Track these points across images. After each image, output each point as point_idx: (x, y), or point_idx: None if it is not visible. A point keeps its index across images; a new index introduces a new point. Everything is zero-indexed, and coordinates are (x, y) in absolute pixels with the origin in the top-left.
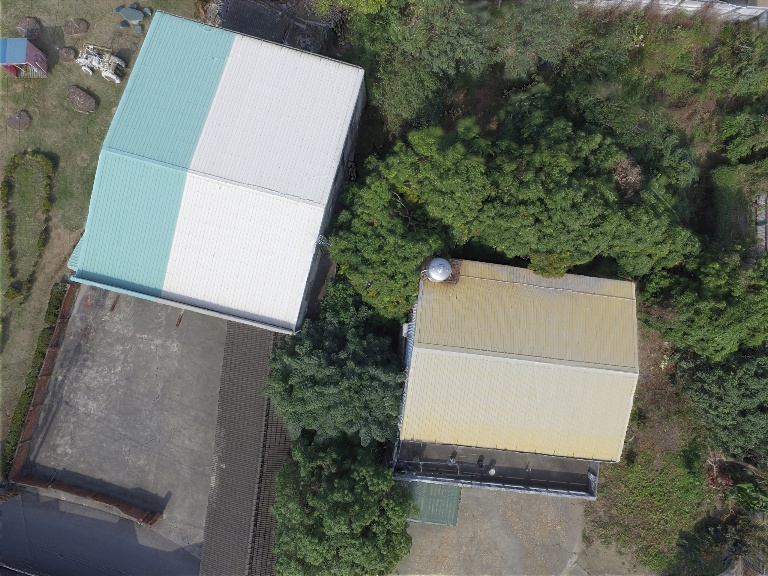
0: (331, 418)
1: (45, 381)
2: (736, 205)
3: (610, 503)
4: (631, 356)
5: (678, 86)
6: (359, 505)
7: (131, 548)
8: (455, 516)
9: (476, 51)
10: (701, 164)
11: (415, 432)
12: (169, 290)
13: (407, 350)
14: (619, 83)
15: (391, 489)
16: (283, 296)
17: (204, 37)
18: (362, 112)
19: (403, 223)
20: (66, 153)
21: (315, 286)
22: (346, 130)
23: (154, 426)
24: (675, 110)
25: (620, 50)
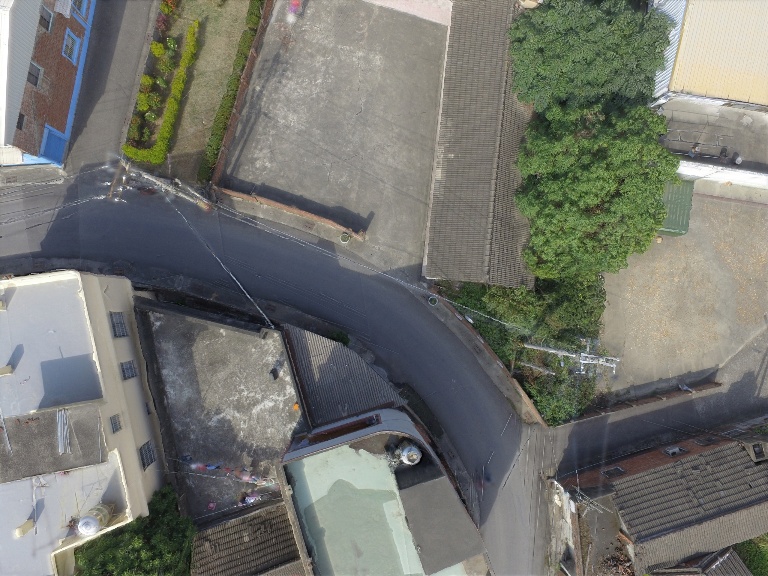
0: (595, 68)
1: (243, 90)
2: None
3: None
4: None
5: None
6: None
7: (332, 270)
8: (687, 222)
9: None
10: None
11: (686, 83)
12: None
13: None
14: None
15: None
16: None
17: None
18: None
19: None
20: None
21: None
22: None
23: (357, 141)
24: None
25: None
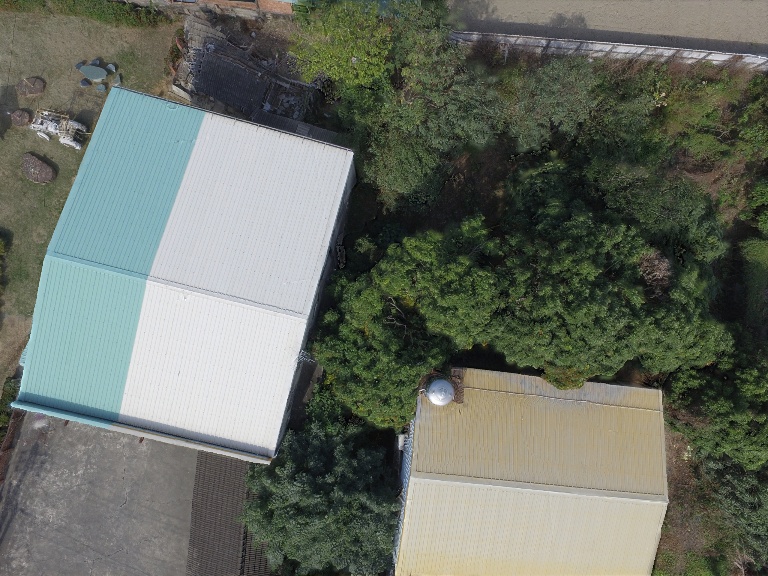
0: (316, 553)
1: None
2: None
3: None
4: (659, 480)
5: (703, 148)
6: None
7: None
8: None
9: (481, 121)
10: (728, 234)
11: (413, 569)
12: (127, 413)
13: (403, 465)
14: (638, 146)
15: None
16: (260, 418)
17: (168, 116)
18: (352, 188)
19: (398, 334)
20: (20, 229)
21: (299, 387)
22: (332, 225)
23: (121, 535)
24: (700, 176)
25: (640, 111)
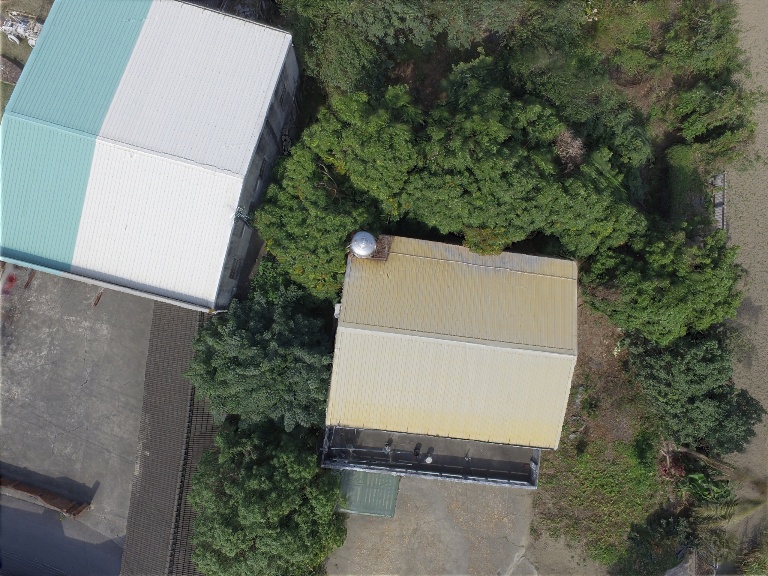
0: (253, 402)
1: None
2: (691, 186)
3: (559, 494)
4: (569, 338)
5: (633, 63)
6: (277, 493)
7: (56, 540)
8: (393, 507)
9: (415, 20)
10: (657, 144)
11: (341, 417)
12: (78, 265)
13: None
14: (572, 59)
15: (317, 477)
16: (201, 272)
17: None
18: (298, 84)
19: (328, 195)
20: None
21: (246, 265)
22: (269, 97)
23: (81, 412)
24: (630, 88)
25: (572, 24)
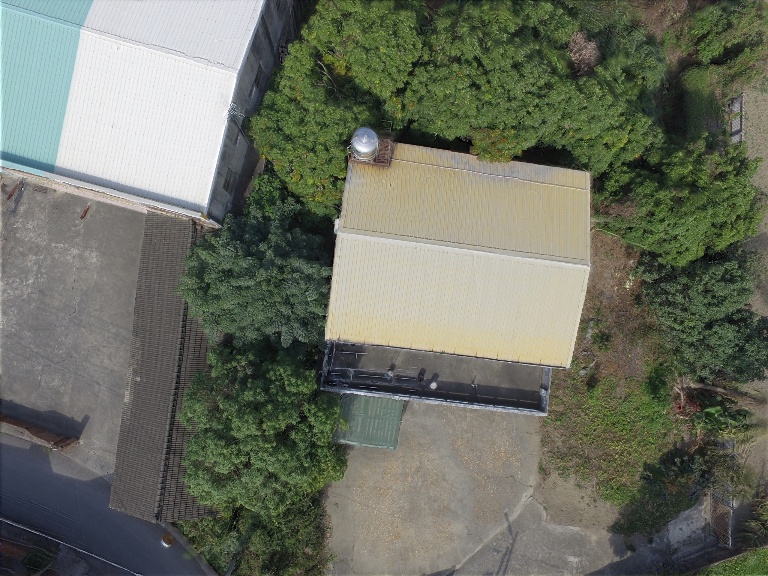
0: (248, 315)
1: None
2: (707, 109)
3: (569, 432)
4: (582, 249)
5: None
6: (273, 405)
7: (44, 476)
8: (395, 438)
9: None
10: (671, 69)
11: (342, 331)
12: (62, 166)
13: None
14: None
15: (315, 395)
16: (192, 175)
17: None
18: None
19: (327, 93)
20: None
21: (241, 182)
22: None
23: (70, 343)
24: (643, 8)
25: None
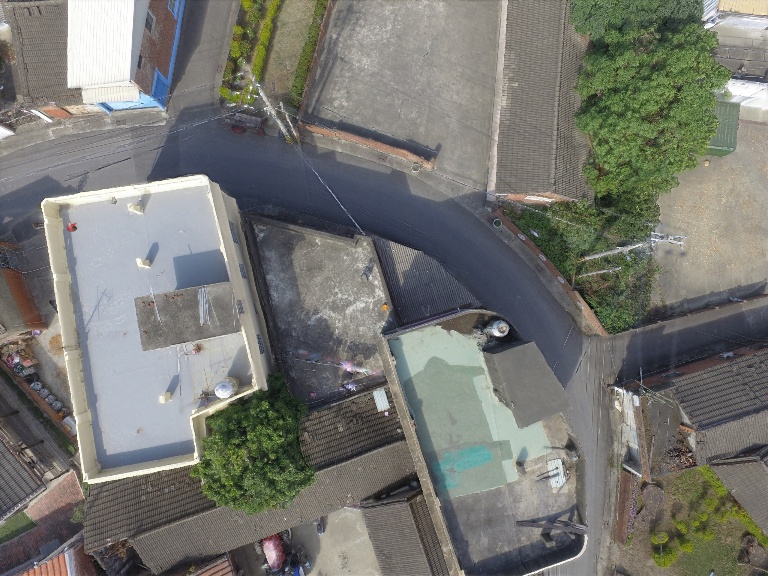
0: None
1: (322, 37)
2: None
3: None
4: None
5: None
6: None
7: (404, 197)
8: (734, 140)
9: None
10: None
11: (734, 2)
12: None
13: None
14: None
15: None
16: None
17: None
18: None
19: None
20: None
21: None
22: None
23: (424, 81)
24: None
25: None
